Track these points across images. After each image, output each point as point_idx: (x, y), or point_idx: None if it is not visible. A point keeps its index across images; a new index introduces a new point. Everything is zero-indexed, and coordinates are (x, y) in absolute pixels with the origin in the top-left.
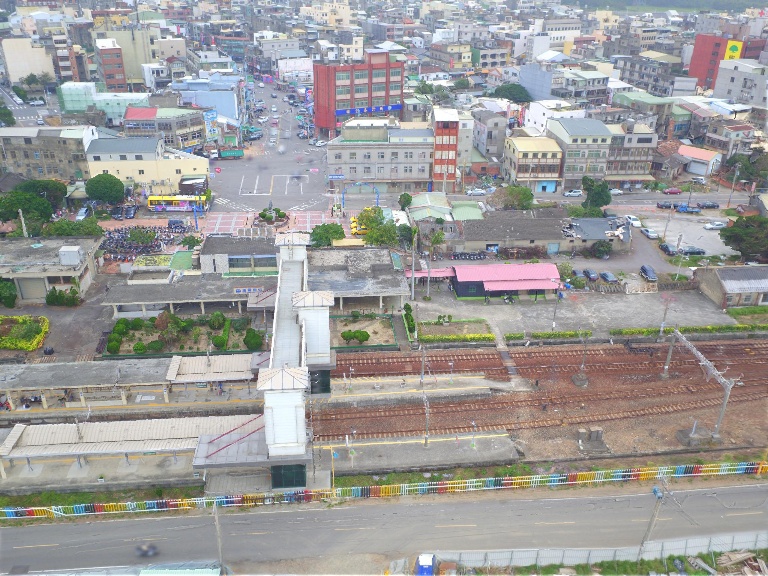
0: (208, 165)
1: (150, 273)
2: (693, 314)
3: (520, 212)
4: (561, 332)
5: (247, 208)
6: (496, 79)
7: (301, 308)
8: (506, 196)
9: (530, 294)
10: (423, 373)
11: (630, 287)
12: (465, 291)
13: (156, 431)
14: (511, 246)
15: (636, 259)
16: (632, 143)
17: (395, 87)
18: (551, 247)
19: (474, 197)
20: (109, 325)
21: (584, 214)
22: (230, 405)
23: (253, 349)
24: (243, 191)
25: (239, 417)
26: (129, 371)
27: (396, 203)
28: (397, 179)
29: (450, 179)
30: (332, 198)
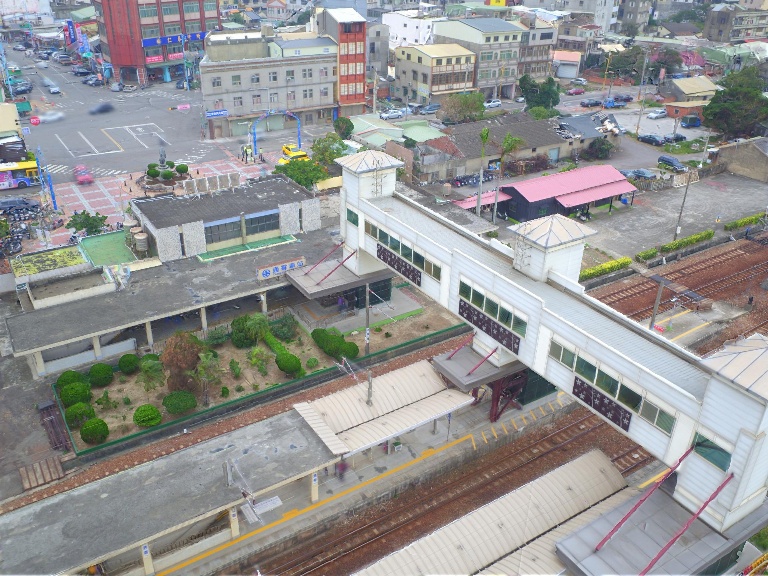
0: (16, 114)
1: (61, 282)
2: (760, 194)
3: (485, 122)
4: (688, 238)
5: (107, 171)
6: (279, 11)
7: (549, 249)
8: (460, 106)
9: (597, 205)
10: (653, 322)
11: (676, 179)
12: (535, 215)
13: (436, 570)
14: (513, 159)
15: (634, 154)
16: (536, 40)
17: (210, 7)
18: (551, 154)
19: (393, 120)
20: (38, 392)
21: (547, 116)
22: (428, 464)
23: (349, 360)
24: (76, 152)
25: (550, 478)
26: (234, 463)
27: (310, 138)
28: (295, 108)
29: (359, 101)
30: (219, 144)
